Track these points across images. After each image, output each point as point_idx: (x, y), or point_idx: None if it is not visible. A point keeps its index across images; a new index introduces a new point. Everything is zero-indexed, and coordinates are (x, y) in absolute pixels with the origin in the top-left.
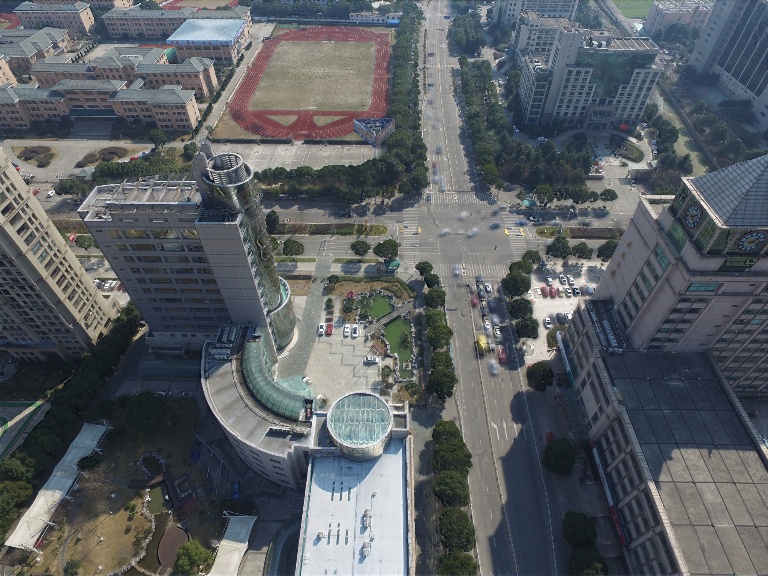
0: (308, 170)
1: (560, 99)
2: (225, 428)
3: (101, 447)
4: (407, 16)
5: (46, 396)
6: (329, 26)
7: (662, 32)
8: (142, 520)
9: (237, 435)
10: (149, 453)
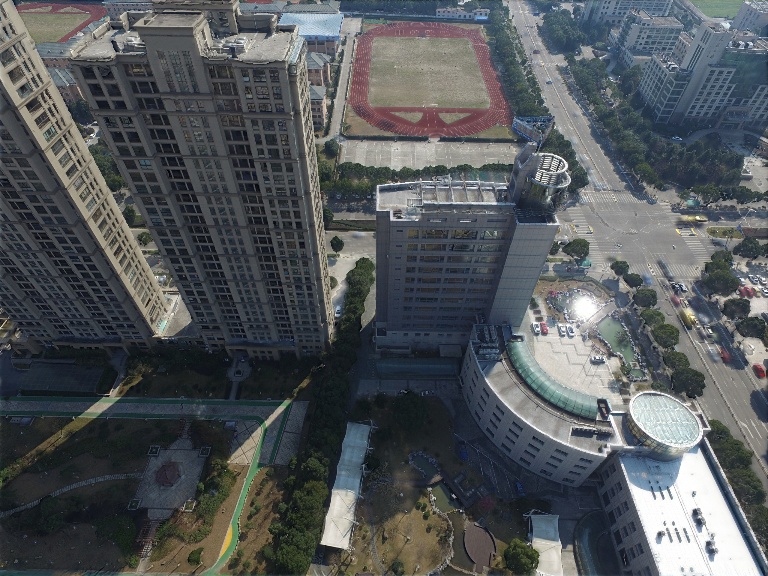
0: (471, 168)
1: (696, 99)
2: (532, 428)
3: (372, 446)
4: (496, 13)
5: (292, 395)
6: (416, 22)
7: (759, 32)
8: (437, 519)
9: (548, 435)
10: (416, 452)
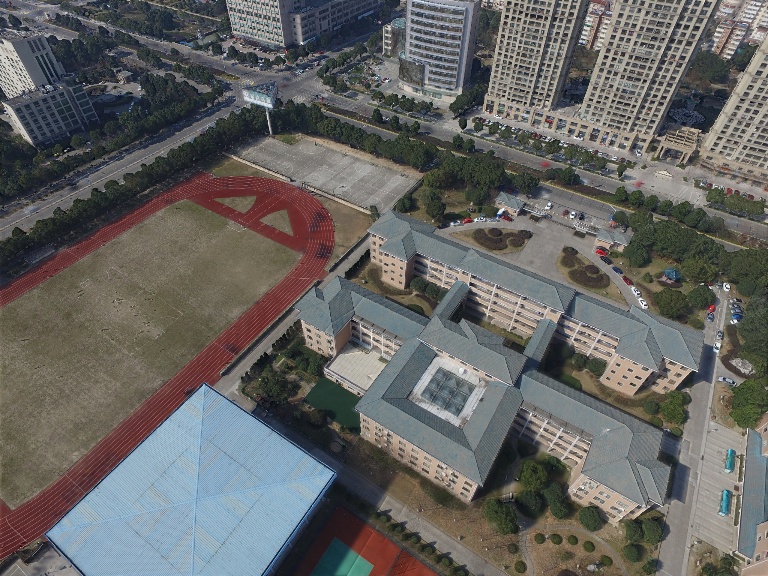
0: None
1: None
2: None
3: None
4: None
5: None
6: None
7: None
8: None
9: None
10: None
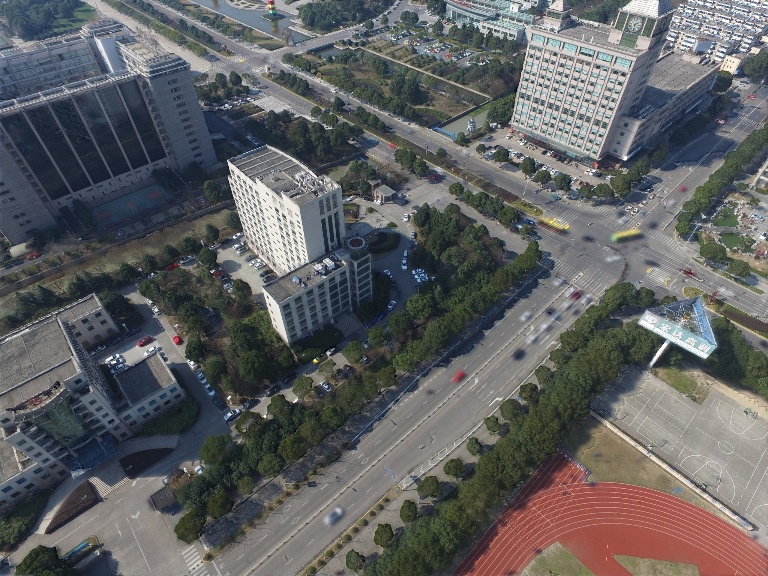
0: None
1: None
2: None
3: None
4: None
5: None
6: None
7: None
8: None
9: None
10: None
